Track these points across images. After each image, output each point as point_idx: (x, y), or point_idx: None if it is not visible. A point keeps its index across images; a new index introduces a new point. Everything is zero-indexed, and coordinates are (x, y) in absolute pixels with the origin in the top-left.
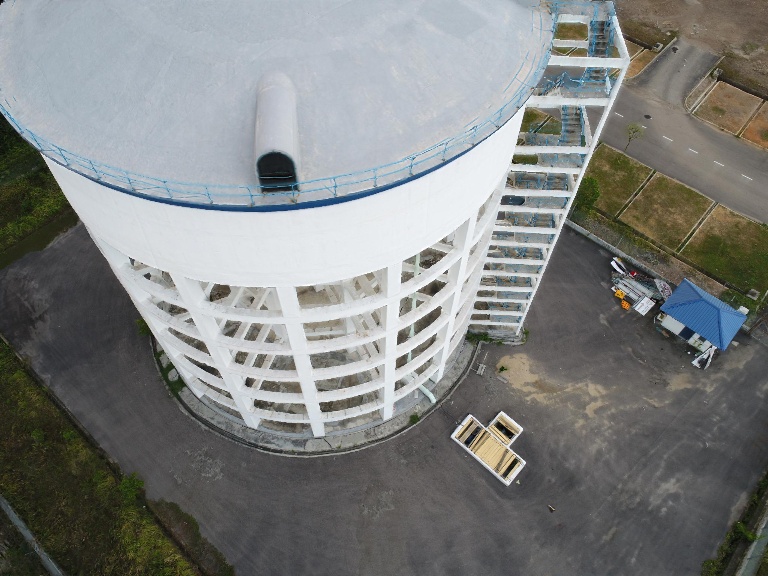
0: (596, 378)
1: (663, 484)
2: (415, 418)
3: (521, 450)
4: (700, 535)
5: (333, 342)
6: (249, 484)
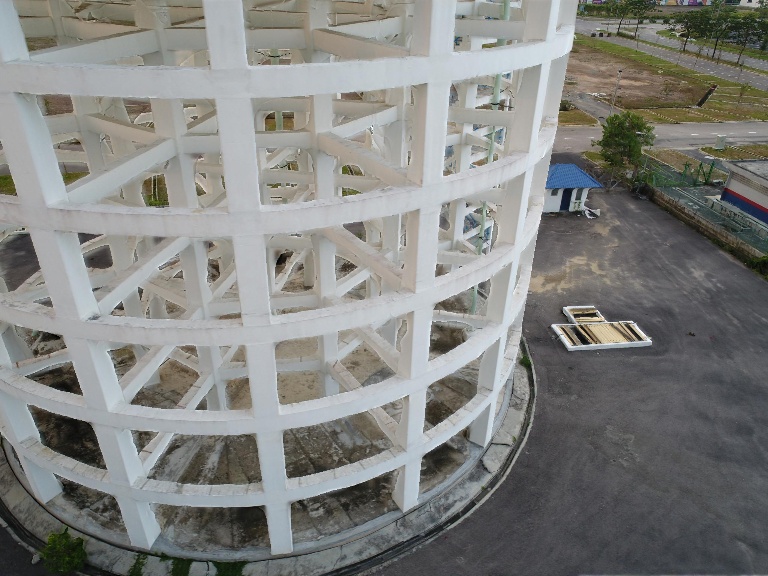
0: (568, 255)
1: (694, 275)
2: (526, 359)
3: (614, 320)
4: (750, 282)
5: (543, 136)
6: (500, 572)
